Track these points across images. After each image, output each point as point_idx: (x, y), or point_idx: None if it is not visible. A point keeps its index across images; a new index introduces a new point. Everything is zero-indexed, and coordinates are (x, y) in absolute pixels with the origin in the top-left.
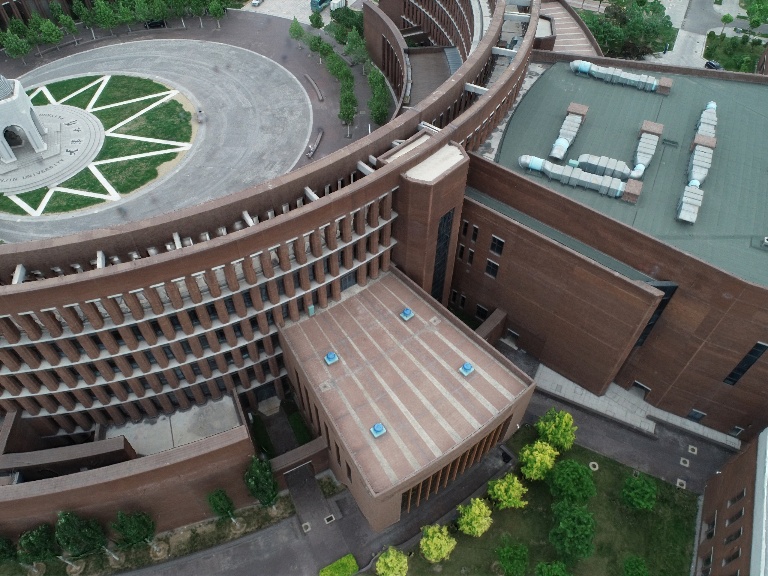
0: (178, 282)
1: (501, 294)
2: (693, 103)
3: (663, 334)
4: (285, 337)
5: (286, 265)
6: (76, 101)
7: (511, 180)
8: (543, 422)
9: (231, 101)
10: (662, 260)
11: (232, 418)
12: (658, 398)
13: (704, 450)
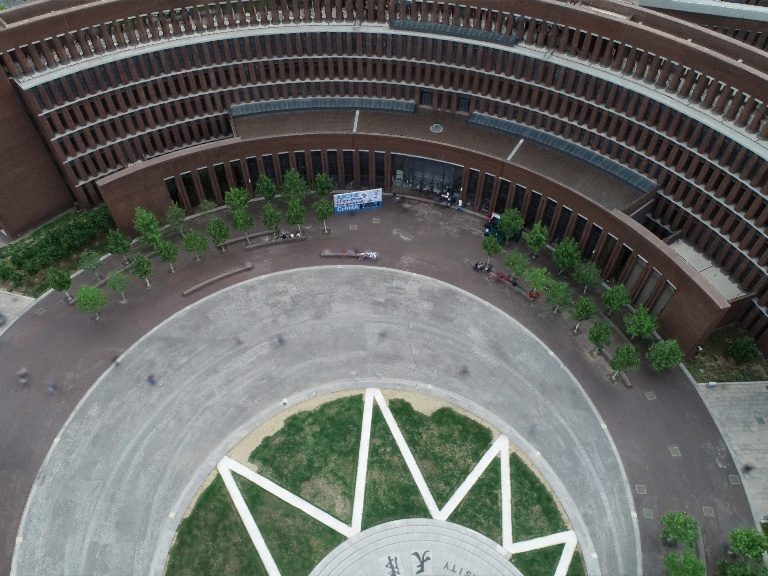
0: None
1: None
2: None
3: None
4: None
5: None
6: None
7: None
8: None
9: (254, 371)
10: None
11: None
12: None
13: None
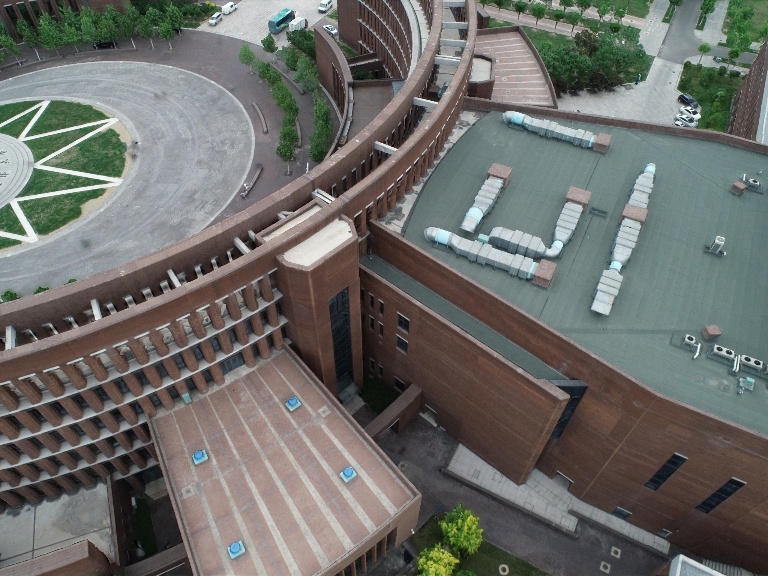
0: (6, 385)
1: (414, 370)
2: (632, 163)
3: (579, 431)
4: (151, 431)
5: (142, 359)
6: (10, 129)
7: (414, 255)
8: (445, 523)
9: (171, 131)
10: (569, 358)
11: (103, 510)
12: (581, 491)
13: (628, 553)
